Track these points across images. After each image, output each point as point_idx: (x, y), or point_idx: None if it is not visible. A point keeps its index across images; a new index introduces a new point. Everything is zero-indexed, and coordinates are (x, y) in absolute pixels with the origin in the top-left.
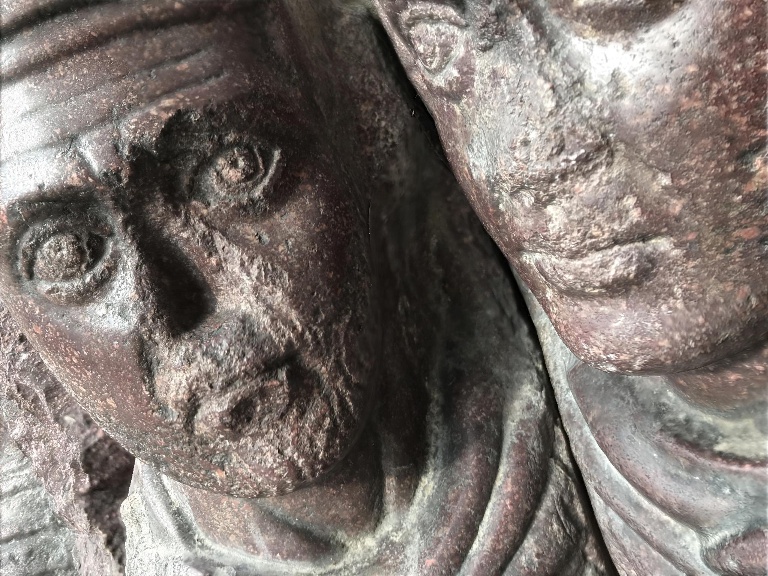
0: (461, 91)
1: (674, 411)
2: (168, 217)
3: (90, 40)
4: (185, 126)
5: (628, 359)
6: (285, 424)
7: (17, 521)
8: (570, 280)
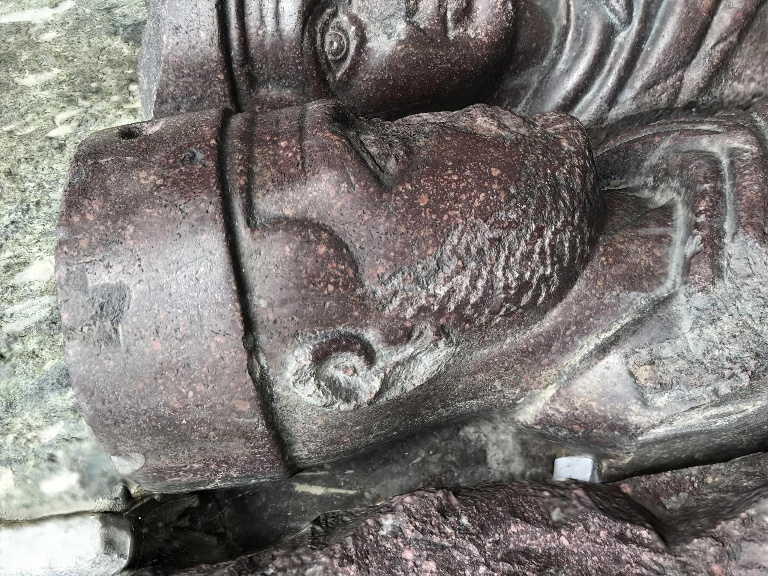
0: (362, 31)
1: (552, 57)
2: None
3: None
4: None
5: None
6: None
7: None
8: None
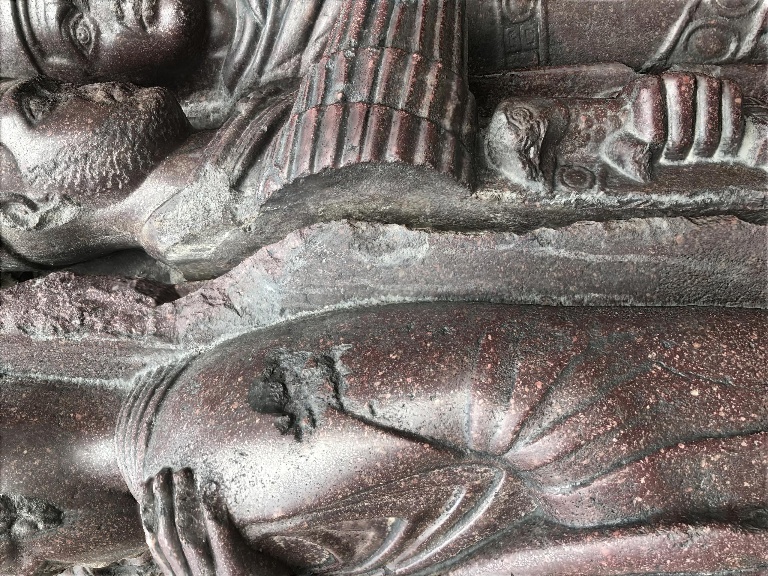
0: (97, 27)
1: None
2: (59, 90)
3: (2, 81)
4: (44, 78)
5: (177, 4)
6: None
7: None
8: (148, 5)
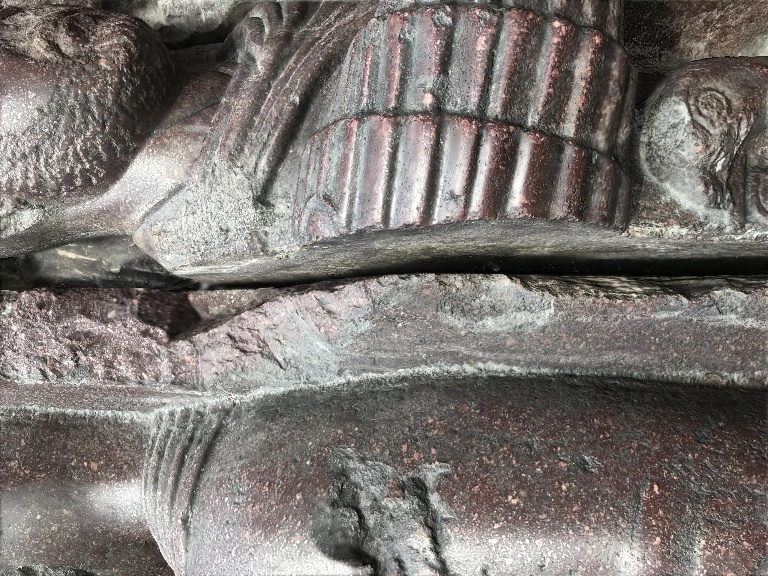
0: None
1: None
2: None
3: None
4: None
5: None
6: (101, 25)
7: (177, 452)
8: None
